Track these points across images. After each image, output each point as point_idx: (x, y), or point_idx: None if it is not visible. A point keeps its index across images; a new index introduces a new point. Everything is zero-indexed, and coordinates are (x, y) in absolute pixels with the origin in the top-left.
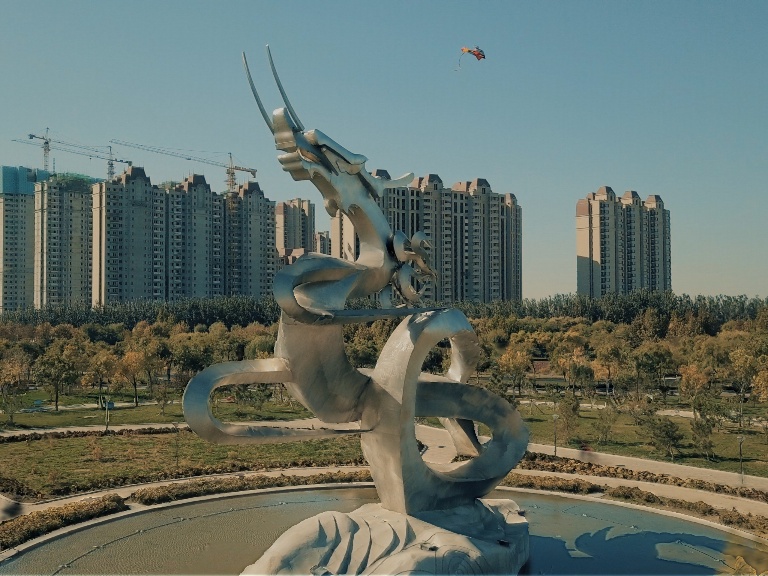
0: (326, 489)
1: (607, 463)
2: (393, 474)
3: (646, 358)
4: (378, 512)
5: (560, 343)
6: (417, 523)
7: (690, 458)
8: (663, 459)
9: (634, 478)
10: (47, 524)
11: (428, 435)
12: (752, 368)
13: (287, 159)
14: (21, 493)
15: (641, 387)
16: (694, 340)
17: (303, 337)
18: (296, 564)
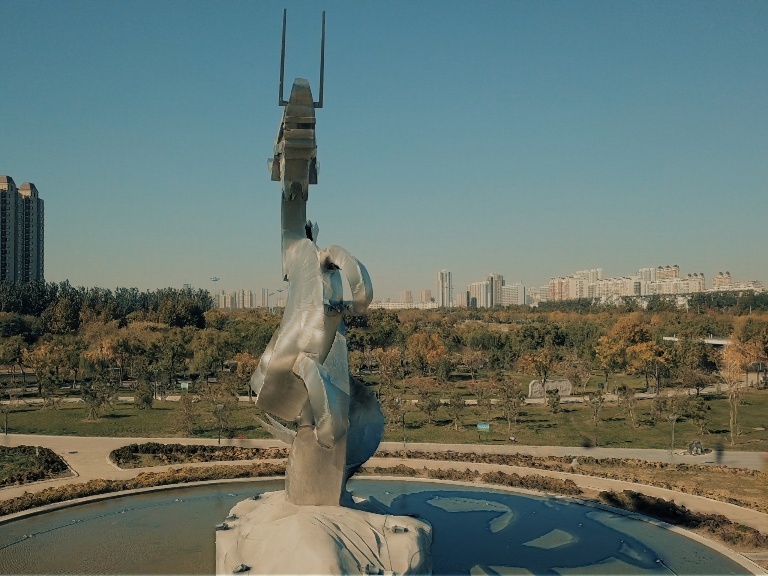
0: (43, 513)
1: (260, 447)
2: (332, 467)
3: (181, 348)
4: (312, 509)
5: (55, 336)
6: (356, 512)
7: None
8: None
9: None
10: None
11: (31, 443)
12: None
13: (297, 135)
14: None
15: (168, 377)
16: (185, 330)
17: (328, 329)
18: (348, 569)
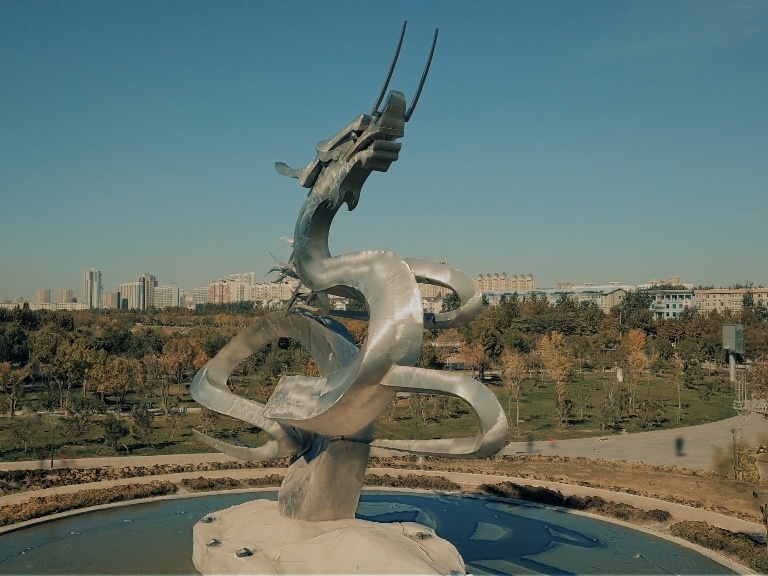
0: None
1: (91, 467)
2: (354, 480)
3: None
4: (336, 524)
5: None
6: None
7: (137, 449)
8: (120, 454)
9: (163, 472)
10: None
11: None
12: (86, 362)
13: (385, 146)
14: None
15: None
16: None
17: None
18: None
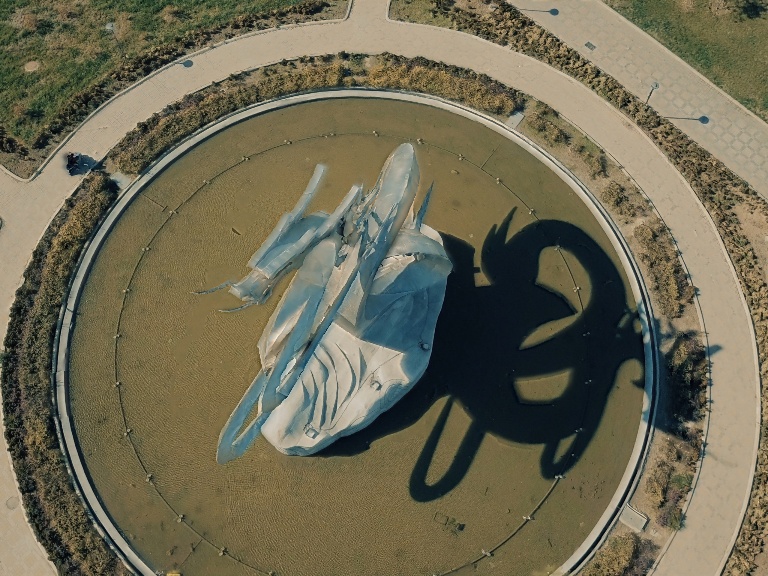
0: (277, 109)
1: (542, 4)
2: None
3: None
4: (339, 335)
5: None
6: (367, 349)
7: None
8: None
9: (557, 67)
10: (72, 257)
11: None
12: None
13: None
14: (6, 151)
15: None
16: None
17: None
18: (294, 429)
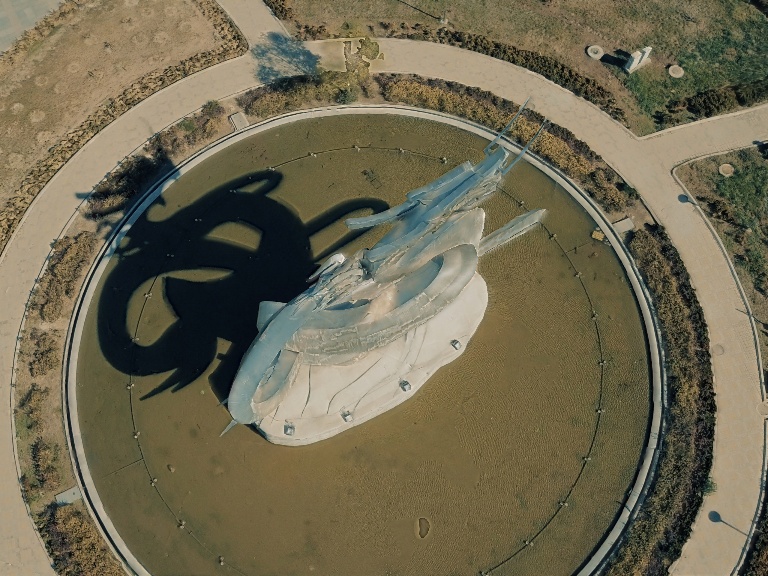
0: None
1: None
2: None
3: None
4: None
5: None
6: None
7: None
8: None
9: None
10: (612, 568)
11: None
12: None
13: None
14: None
15: None
16: None
17: None
18: None
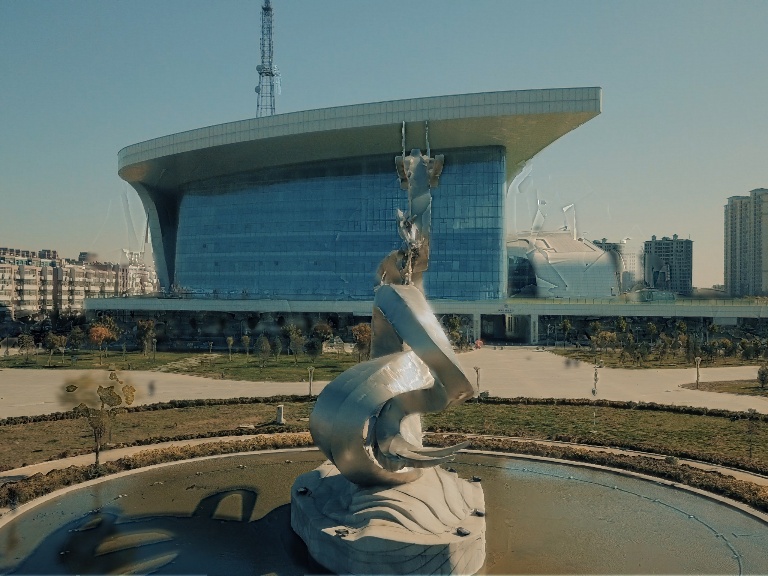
0: None
1: None
2: None
3: None
4: None
5: None
6: None
7: None
8: None
9: None
10: None
11: None
12: None
13: None
14: None
15: None
16: None
17: None
18: None
